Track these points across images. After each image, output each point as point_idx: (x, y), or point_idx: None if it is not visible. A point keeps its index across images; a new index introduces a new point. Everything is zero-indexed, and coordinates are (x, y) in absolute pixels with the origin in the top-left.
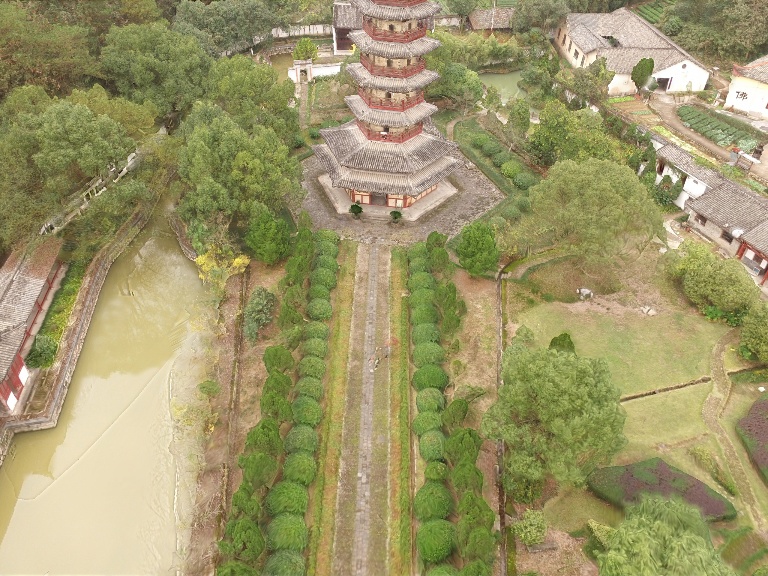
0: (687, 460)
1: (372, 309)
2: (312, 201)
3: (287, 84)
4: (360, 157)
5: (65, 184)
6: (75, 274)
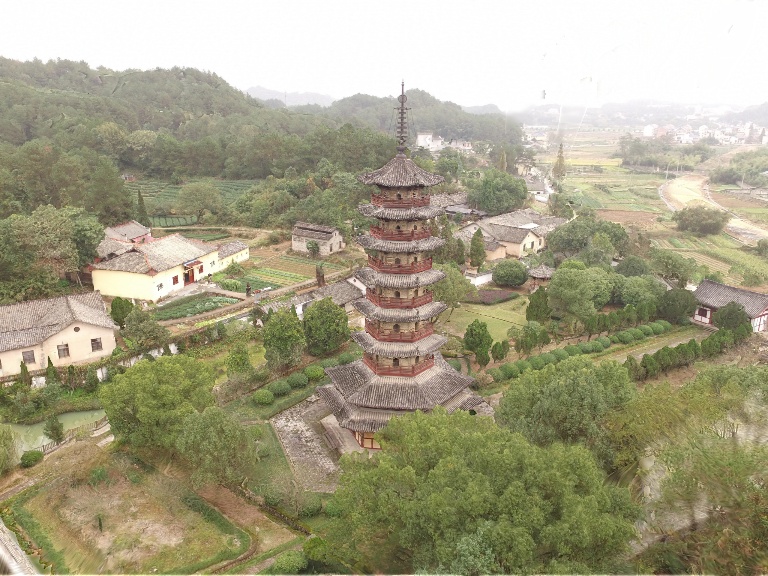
0: None
1: None
2: None
3: (353, 458)
4: None
5: None
6: None
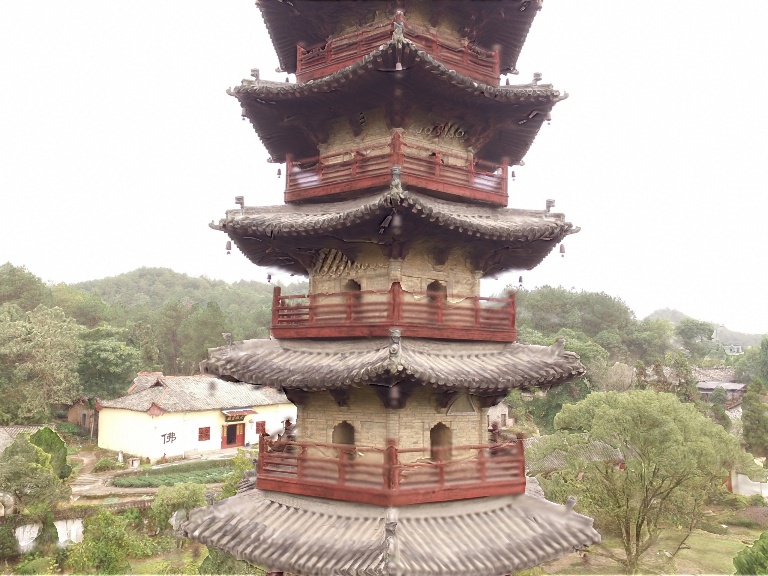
0: None
1: None
2: None
3: None
4: None
5: None
6: None
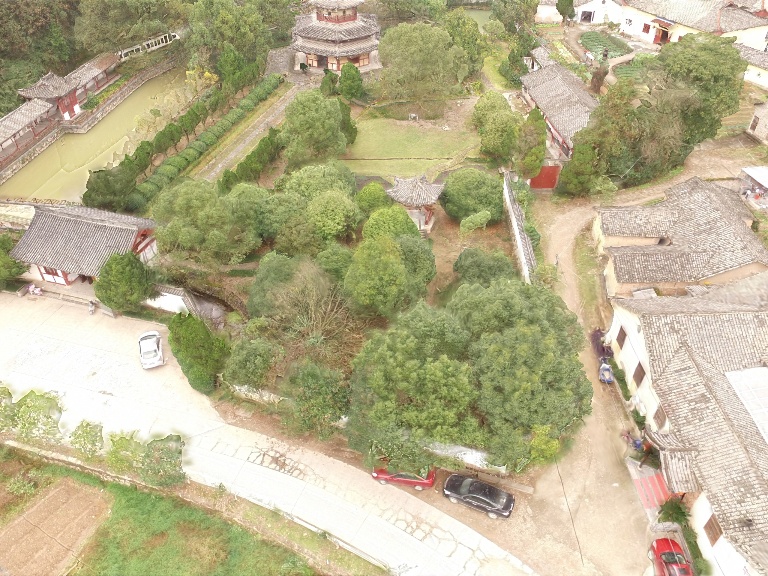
0: None
1: (279, 111)
2: (284, 63)
3: None
4: (309, 30)
5: (119, 15)
6: (124, 78)
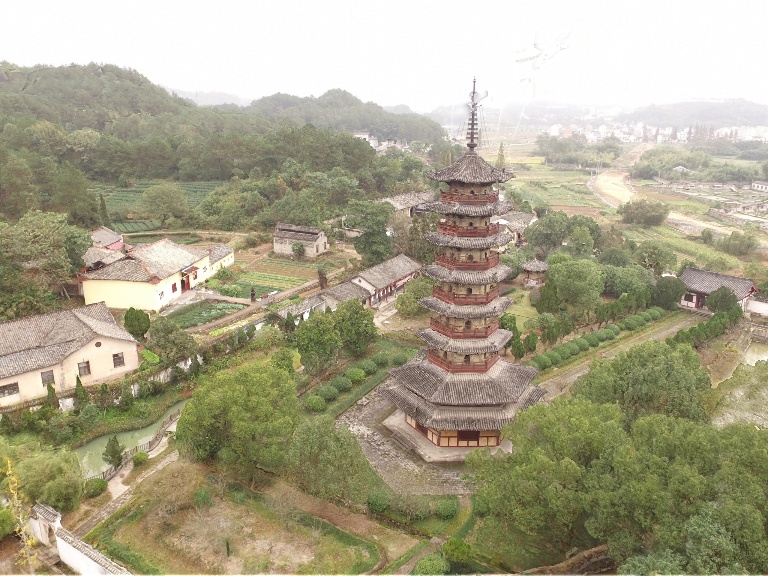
0: (521, 303)
1: (585, 372)
2: None
3: (480, 456)
4: None
5: None
6: None
